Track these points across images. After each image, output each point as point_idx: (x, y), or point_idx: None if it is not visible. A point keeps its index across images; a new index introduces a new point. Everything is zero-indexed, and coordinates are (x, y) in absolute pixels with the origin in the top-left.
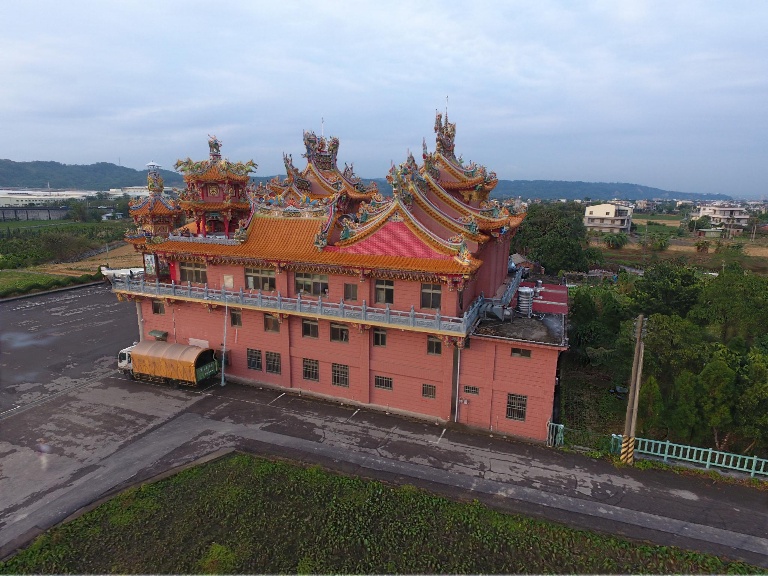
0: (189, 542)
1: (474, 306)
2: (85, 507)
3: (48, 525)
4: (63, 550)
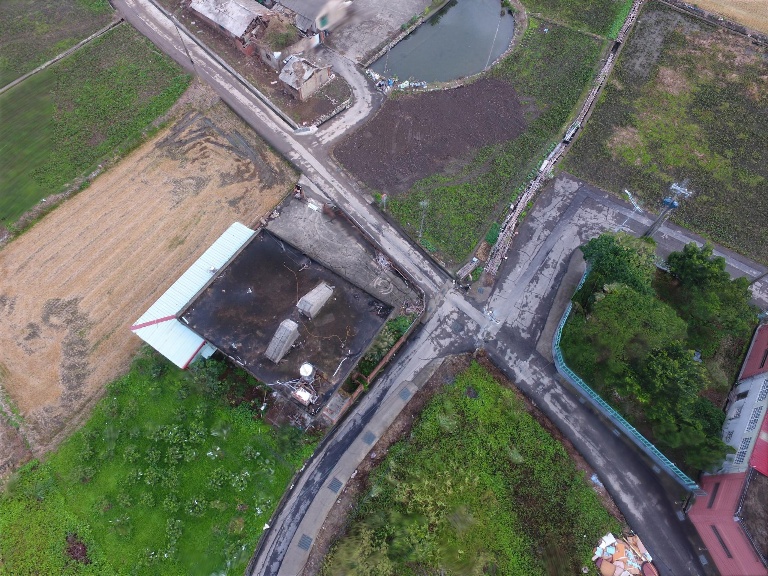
0: None
1: None
2: None
3: None
4: None
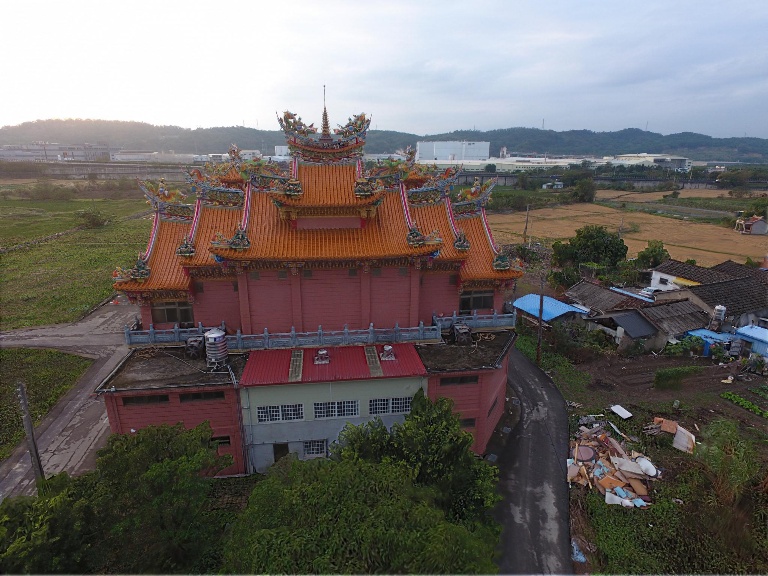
0: (5, 379)
1: (174, 328)
2: (39, 347)
3: (25, 346)
4: (7, 356)
